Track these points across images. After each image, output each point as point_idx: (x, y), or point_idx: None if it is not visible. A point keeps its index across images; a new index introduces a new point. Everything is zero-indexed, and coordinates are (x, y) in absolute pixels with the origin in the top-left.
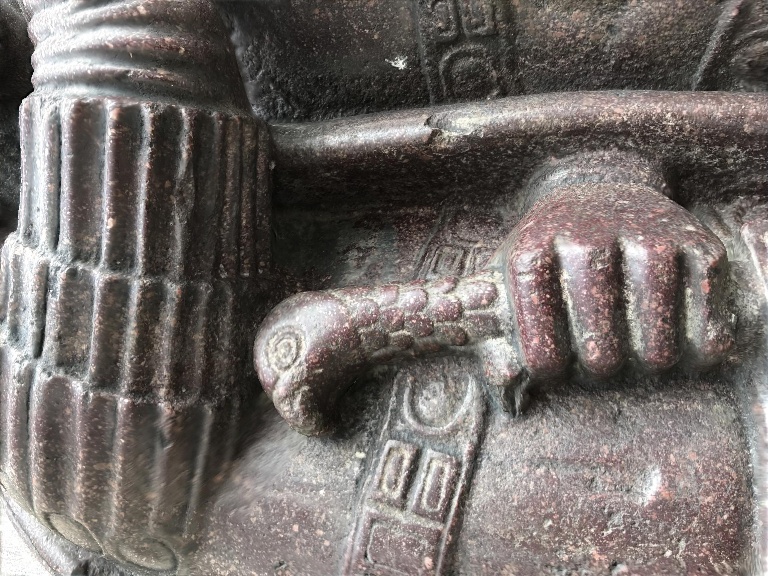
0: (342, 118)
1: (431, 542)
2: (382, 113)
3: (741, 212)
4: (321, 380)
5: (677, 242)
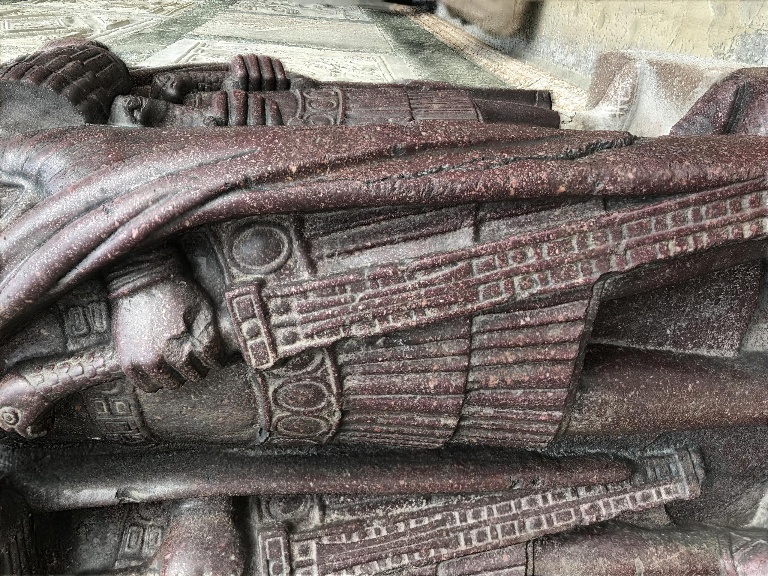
0: (67, 477)
1: None
2: (90, 475)
3: (269, 500)
4: None
5: (225, 573)
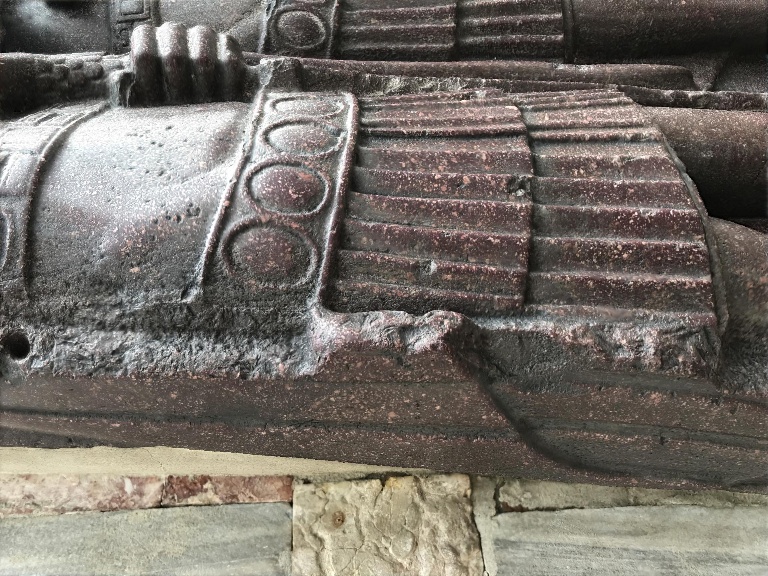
0: None
1: (51, 131)
2: None
3: None
4: (0, 68)
5: None
